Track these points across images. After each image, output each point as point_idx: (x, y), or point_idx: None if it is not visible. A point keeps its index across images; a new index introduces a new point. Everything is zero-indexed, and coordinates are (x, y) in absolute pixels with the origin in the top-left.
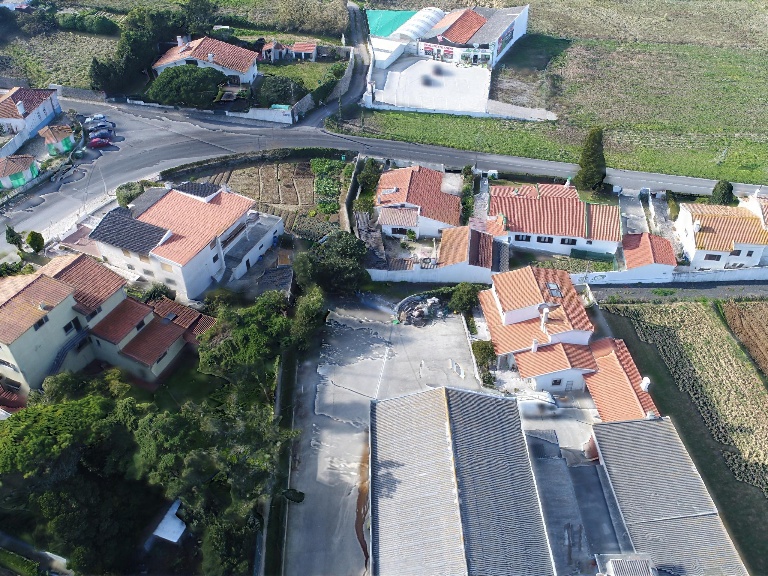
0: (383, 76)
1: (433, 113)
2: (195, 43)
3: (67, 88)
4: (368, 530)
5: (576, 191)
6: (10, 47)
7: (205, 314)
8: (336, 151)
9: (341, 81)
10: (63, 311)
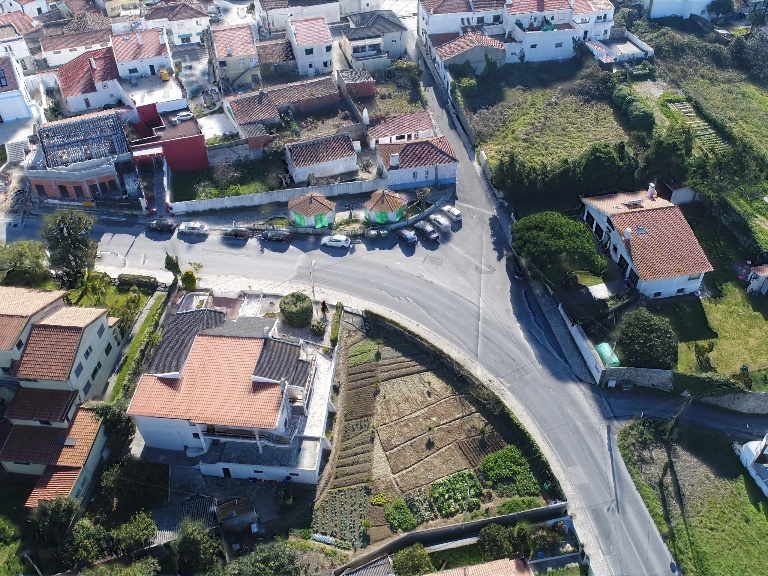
0: None
1: None
2: (655, 204)
3: (487, 165)
4: None
5: None
6: (540, 94)
7: (102, 470)
8: (547, 468)
9: (751, 394)
10: (2, 356)
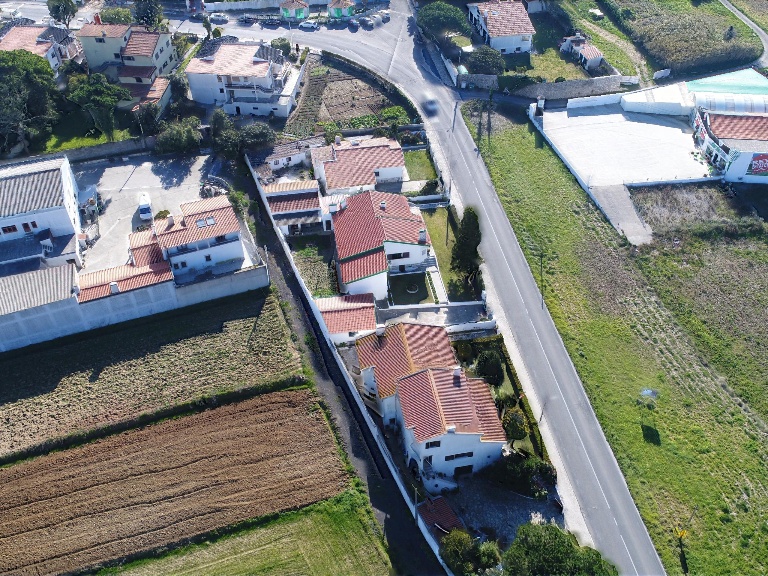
0: (605, 112)
1: (559, 156)
2: None
3: None
4: None
5: (411, 242)
6: None
7: None
8: (416, 112)
9: (539, 85)
10: (116, 45)
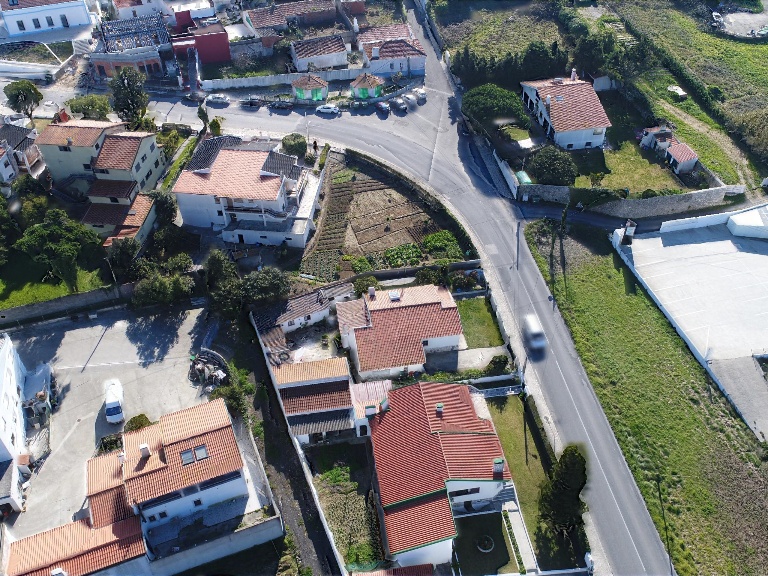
0: (708, 237)
1: (659, 307)
2: (574, 82)
3: None
4: None
5: (483, 478)
6: (501, 15)
7: (155, 231)
8: (469, 241)
9: (624, 201)
10: (85, 154)
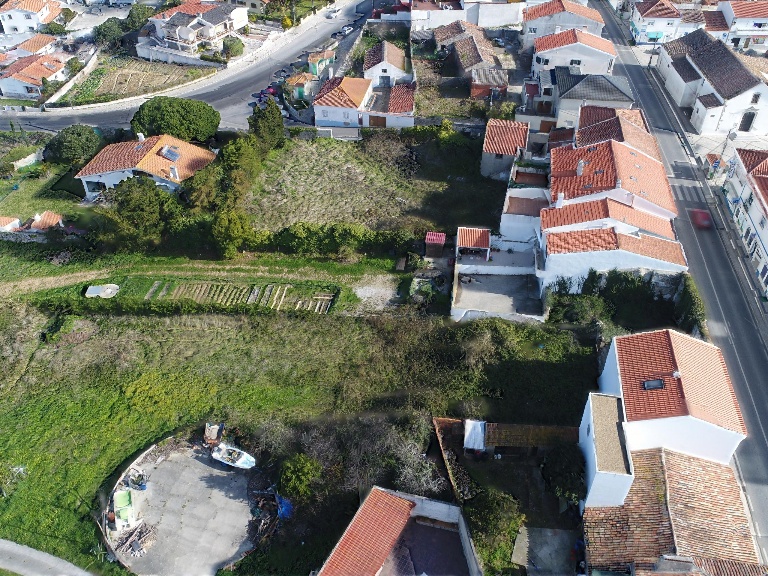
0: None
1: None
2: (155, 162)
3: None
4: None
5: None
6: None
7: None
8: None
9: None
10: None
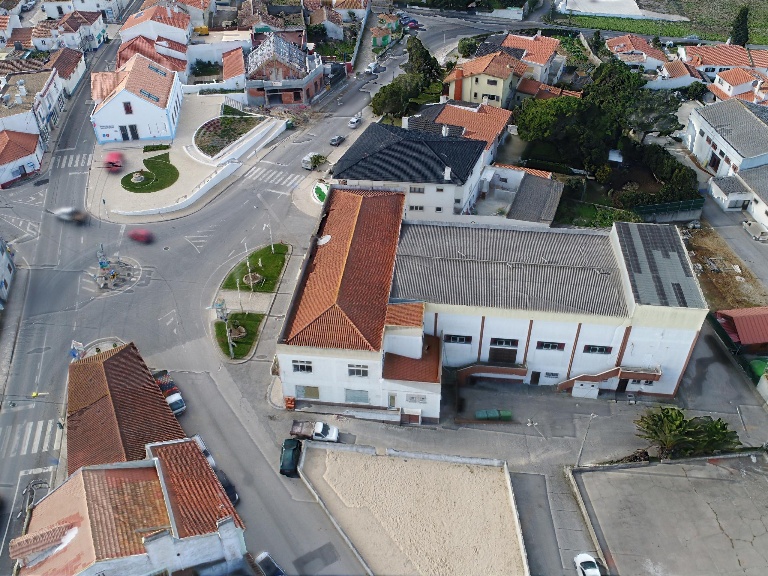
0: None
1: (607, 17)
2: None
3: None
4: (705, 167)
5: (736, 45)
6: None
7: None
8: (566, 31)
9: None
10: (511, 73)
